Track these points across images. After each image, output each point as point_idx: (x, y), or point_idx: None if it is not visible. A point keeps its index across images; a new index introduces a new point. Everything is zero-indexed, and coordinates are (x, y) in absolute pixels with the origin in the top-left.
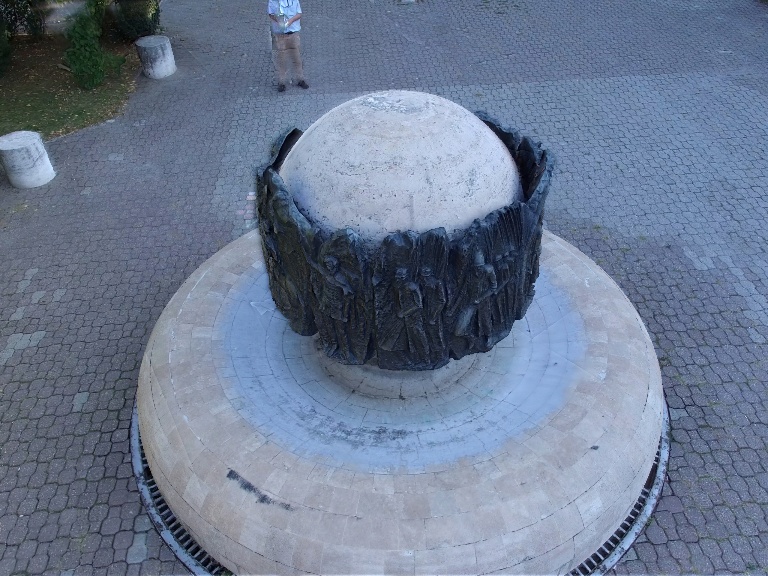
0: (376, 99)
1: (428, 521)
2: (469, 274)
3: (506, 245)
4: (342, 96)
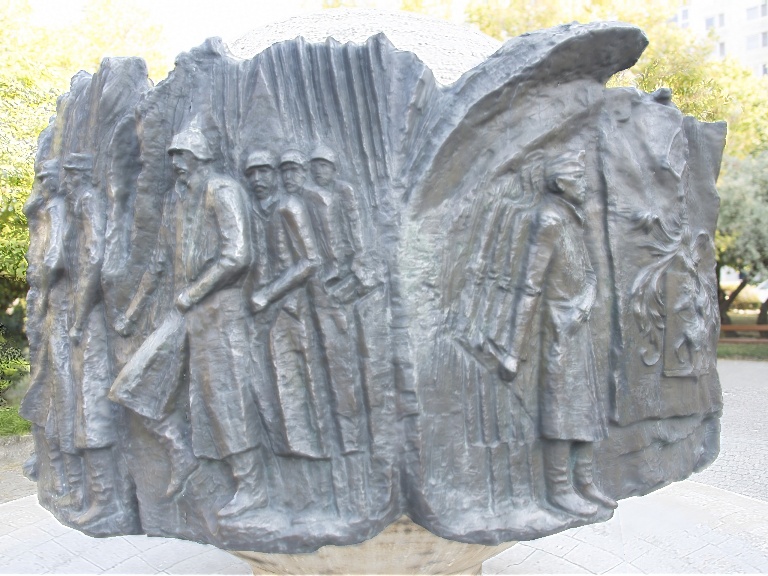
0: None
1: None
2: (168, 192)
3: (296, 133)
4: (741, 440)
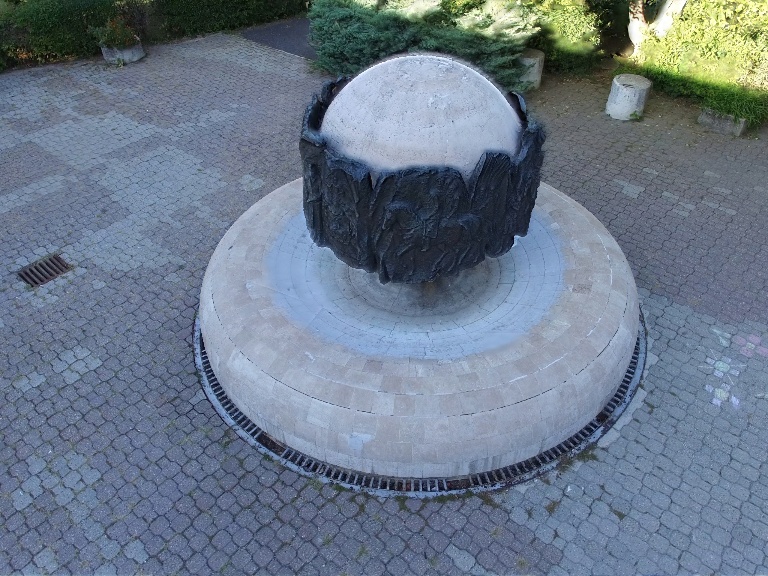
0: (441, 63)
1: (290, 185)
2: None
3: None
4: None
